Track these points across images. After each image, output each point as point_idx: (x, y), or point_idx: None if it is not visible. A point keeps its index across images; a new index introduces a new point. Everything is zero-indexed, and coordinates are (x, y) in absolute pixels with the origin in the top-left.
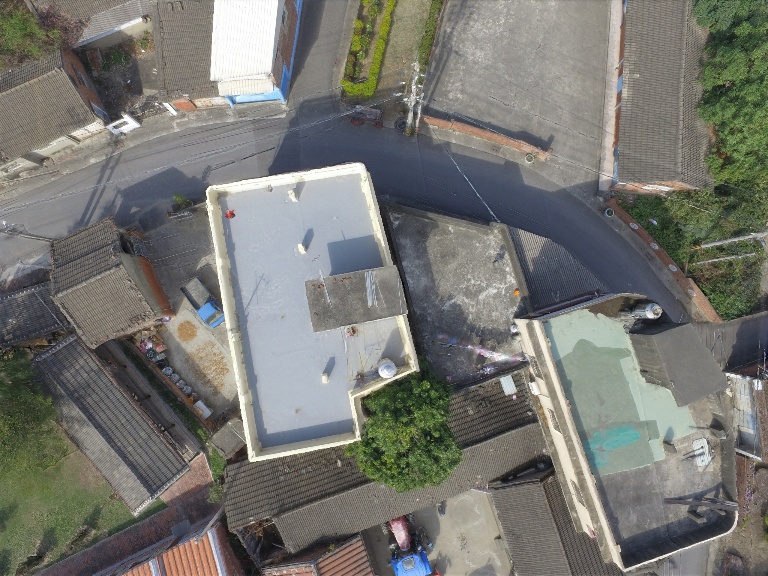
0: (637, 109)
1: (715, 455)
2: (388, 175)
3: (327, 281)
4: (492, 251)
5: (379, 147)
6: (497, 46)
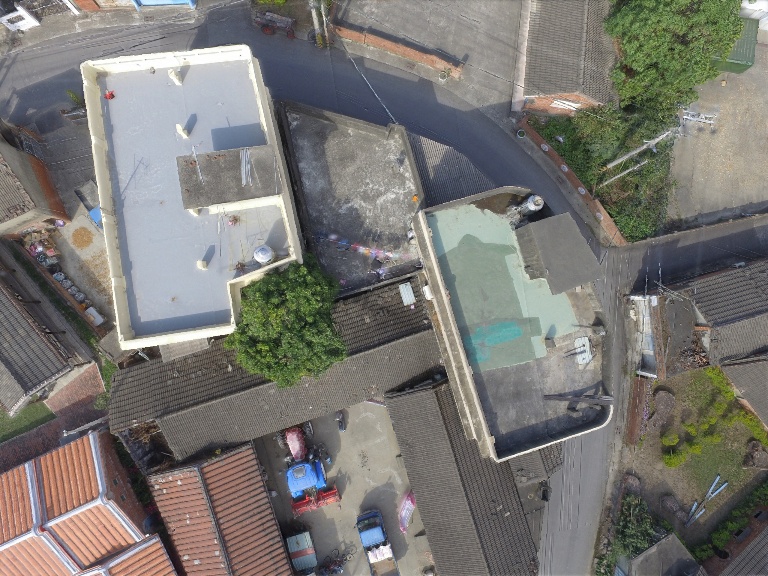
0: (544, 23)
1: (596, 354)
2: (299, 87)
3: (200, 157)
4: (392, 156)
5: (290, 58)
6: None
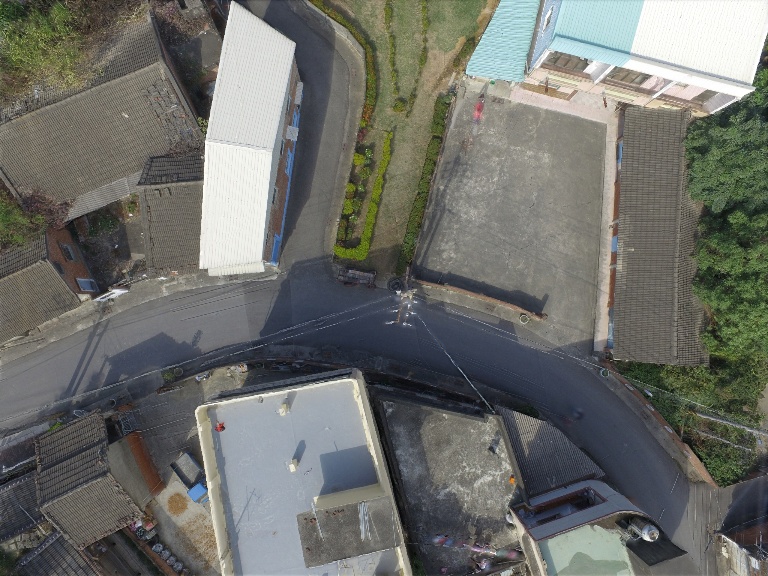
0: (632, 284)
1: None
2: (381, 337)
3: (319, 514)
4: (487, 437)
5: (372, 308)
6: (491, 204)
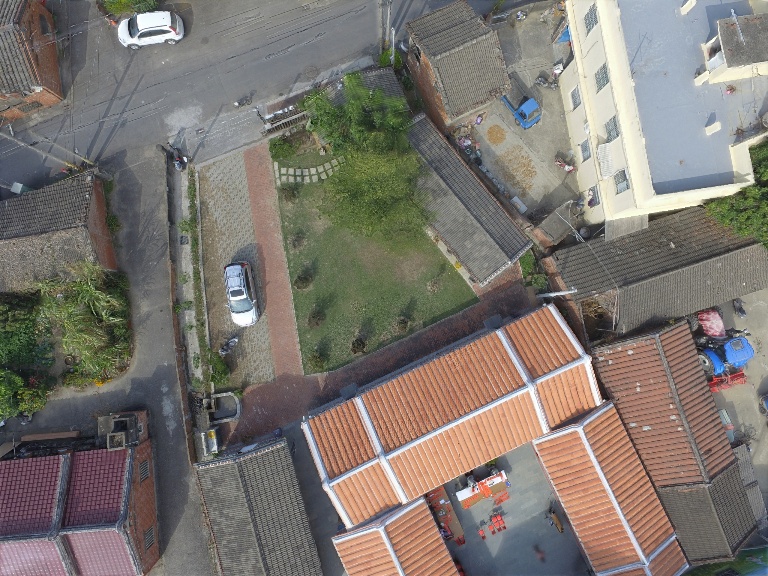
0: None
1: None
2: None
3: (739, 20)
4: None
5: None
6: None
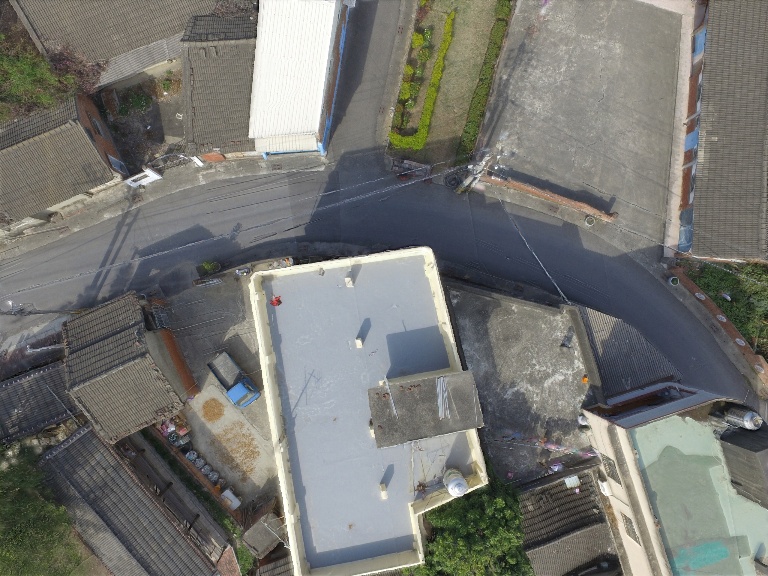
0: (715, 176)
1: None
2: (436, 236)
3: (393, 389)
4: (559, 333)
5: (427, 205)
6: (557, 96)
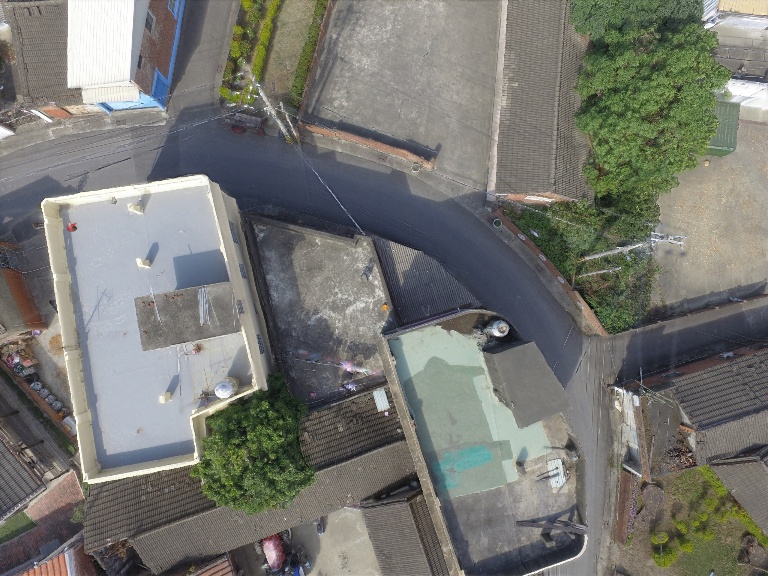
0: (515, 118)
1: (570, 476)
2: (271, 184)
3: (158, 298)
4: (360, 264)
5: (262, 156)
6: (384, 53)
